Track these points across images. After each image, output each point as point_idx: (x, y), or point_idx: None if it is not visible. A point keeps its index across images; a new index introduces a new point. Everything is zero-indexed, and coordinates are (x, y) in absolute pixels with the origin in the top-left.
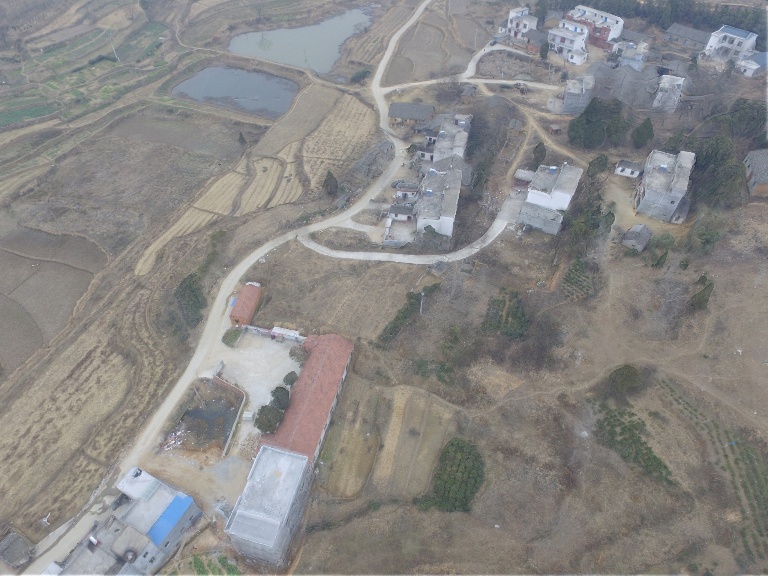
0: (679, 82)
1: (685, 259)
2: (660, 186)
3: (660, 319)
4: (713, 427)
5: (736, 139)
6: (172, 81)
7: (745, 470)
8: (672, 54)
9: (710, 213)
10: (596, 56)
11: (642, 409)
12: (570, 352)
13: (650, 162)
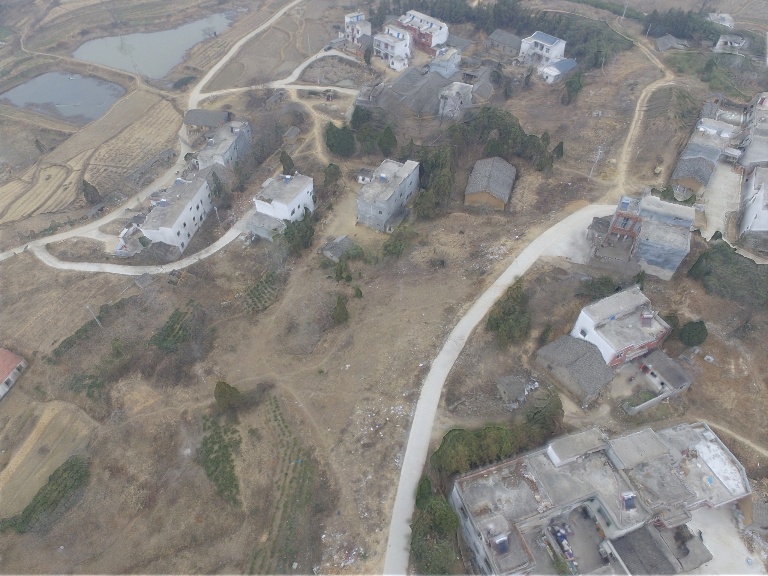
0: (467, 89)
1: (371, 270)
2: (372, 196)
3: (314, 332)
4: (292, 444)
5: (474, 148)
6: (0, 87)
7: (294, 489)
8: (490, 60)
9: (413, 223)
10: (419, 62)
11: (246, 425)
12: (209, 366)
13: (376, 171)
